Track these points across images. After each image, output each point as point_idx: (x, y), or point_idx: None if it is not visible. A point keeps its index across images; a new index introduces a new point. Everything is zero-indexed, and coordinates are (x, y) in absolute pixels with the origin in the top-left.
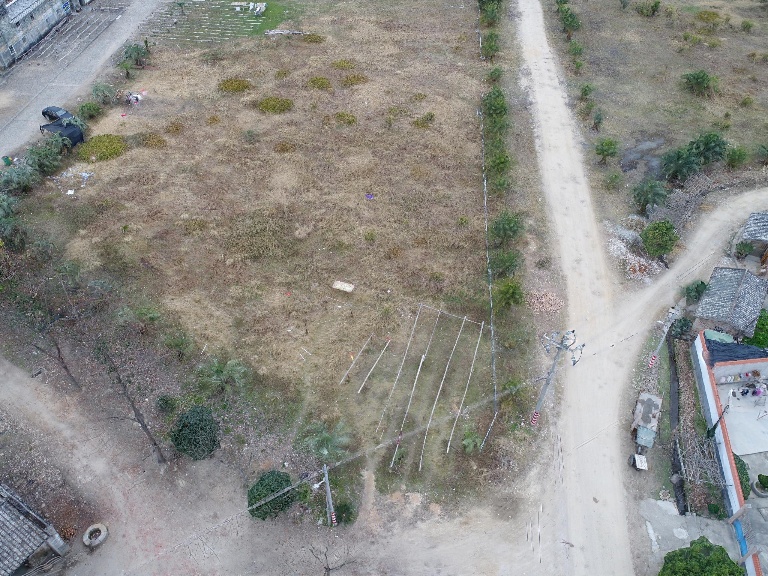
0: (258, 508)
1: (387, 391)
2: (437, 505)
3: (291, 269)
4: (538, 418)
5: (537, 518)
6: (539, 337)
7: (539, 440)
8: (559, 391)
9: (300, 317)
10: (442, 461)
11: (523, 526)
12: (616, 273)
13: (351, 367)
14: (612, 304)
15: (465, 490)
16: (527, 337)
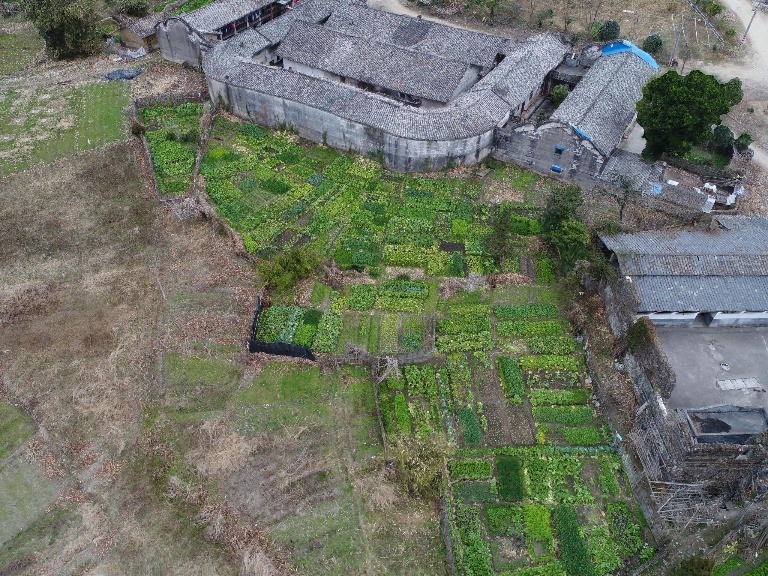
0: (651, 45)
1: (669, 40)
2: (710, 63)
3: None
4: (742, 45)
5: (754, 65)
6: (731, 27)
7: (745, 50)
8: (748, 39)
9: None
10: (706, 54)
11: (749, 67)
12: (760, 11)
13: (649, 32)
14: (762, 19)
15: (720, 60)
16: (726, 27)
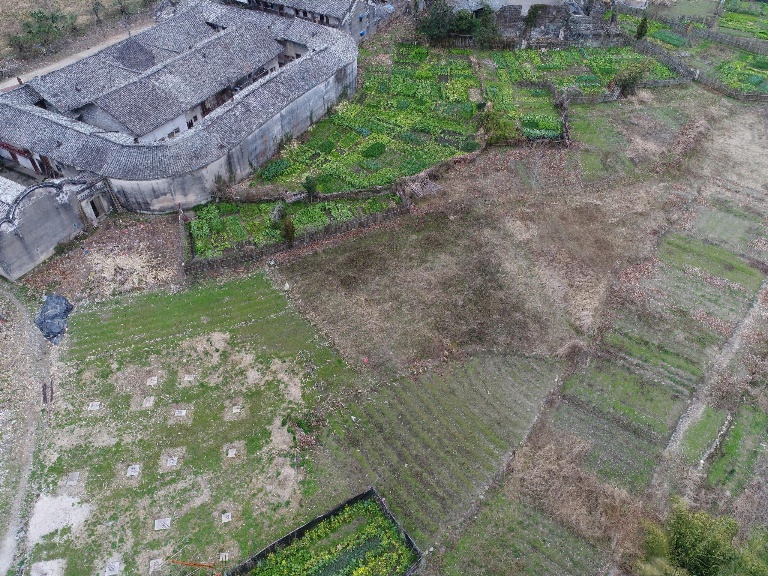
0: None
1: None
2: None
3: (54, 7)
4: None
5: None
6: None
7: None
8: None
9: (91, 3)
10: None
11: None
12: None
13: None
14: None
15: None
16: None
